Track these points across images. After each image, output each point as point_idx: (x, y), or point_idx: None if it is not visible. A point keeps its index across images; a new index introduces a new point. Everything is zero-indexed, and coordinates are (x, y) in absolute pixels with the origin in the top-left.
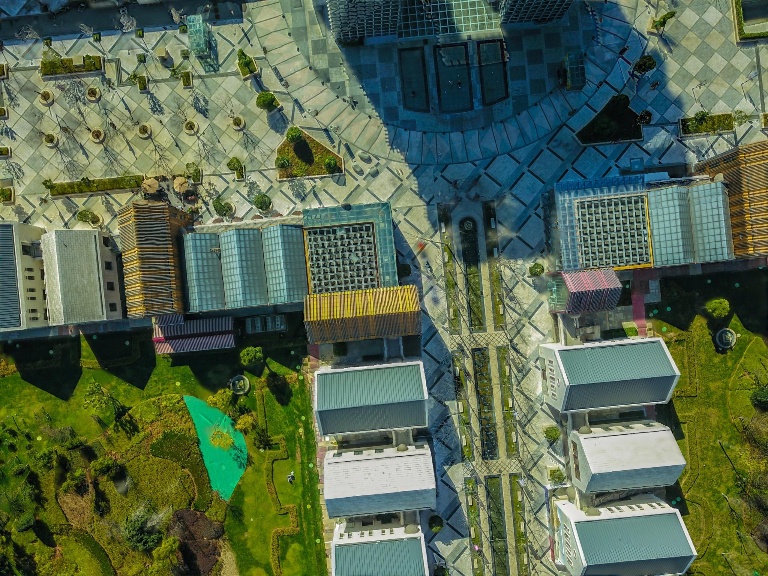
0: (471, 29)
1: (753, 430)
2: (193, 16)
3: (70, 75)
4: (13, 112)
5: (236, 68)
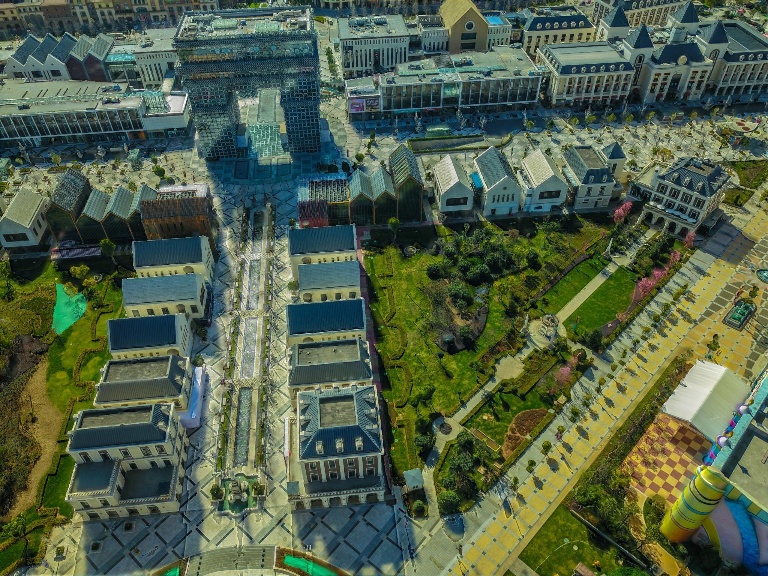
0: (275, 155)
1: (430, 288)
2: (135, 150)
3: (63, 171)
4: (25, 183)
5: (150, 168)
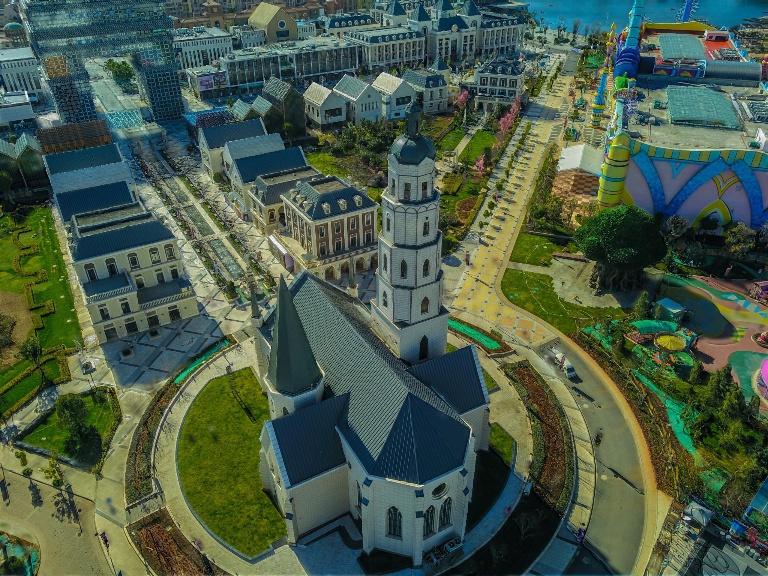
0: (141, 125)
1: None
2: None
3: None
4: None
5: None
